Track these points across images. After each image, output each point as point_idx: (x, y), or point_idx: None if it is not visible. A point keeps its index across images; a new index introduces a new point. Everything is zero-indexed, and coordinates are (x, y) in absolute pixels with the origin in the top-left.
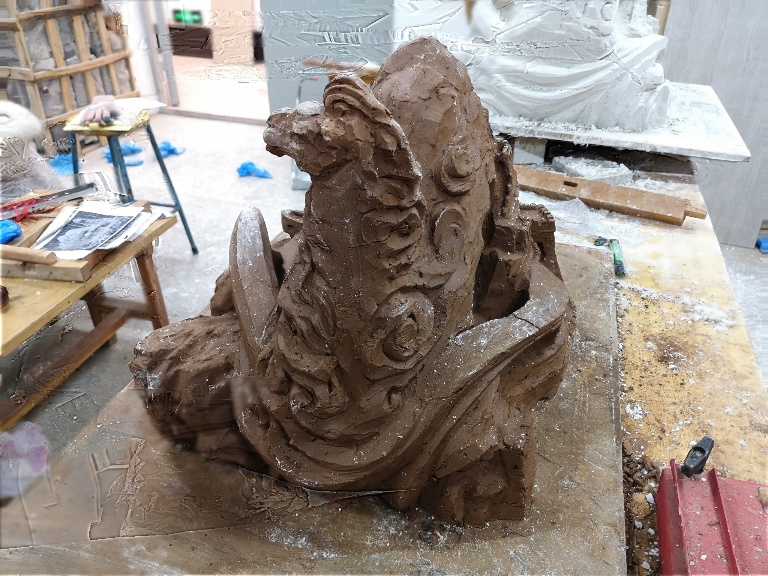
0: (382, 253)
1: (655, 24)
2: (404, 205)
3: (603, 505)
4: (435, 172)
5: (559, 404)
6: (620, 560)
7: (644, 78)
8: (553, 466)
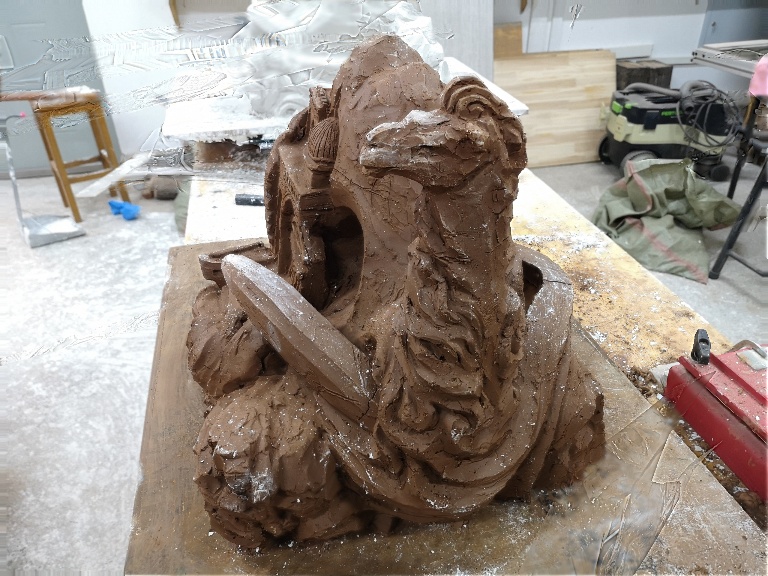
0: None
1: (411, 8)
2: (515, 197)
3: None
4: None
5: None
6: (688, 452)
7: (430, 56)
8: None
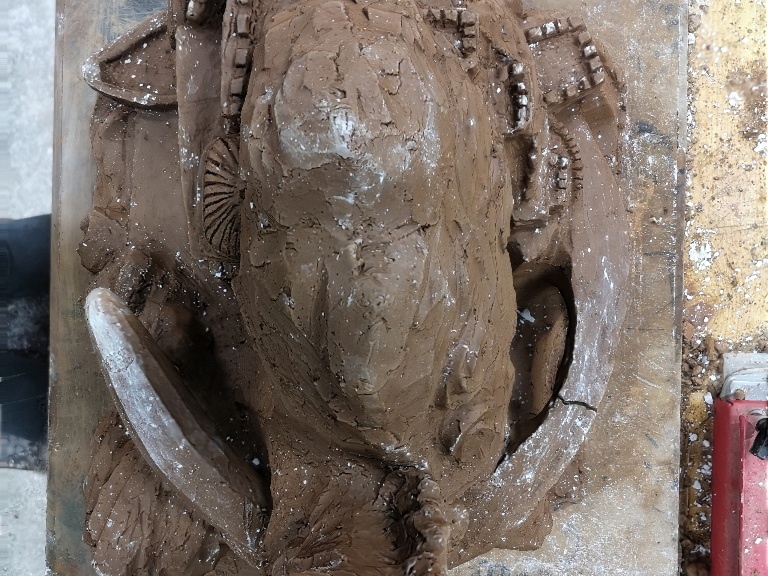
0: None
1: None
2: None
3: (657, 440)
4: (436, 402)
5: None
6: (673, 504)
7: None
8: None
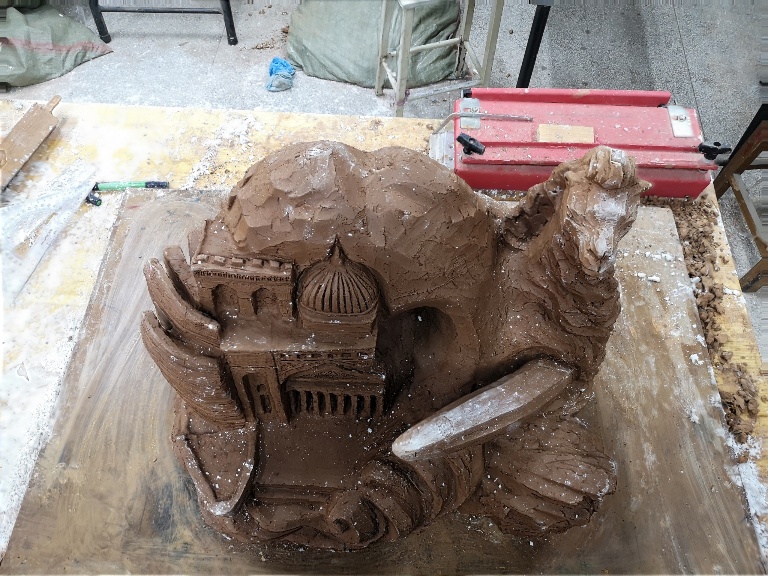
0: None
1: None
2: None
3: None
4: None
5: None
6: (516, 204)
7: None
8: None
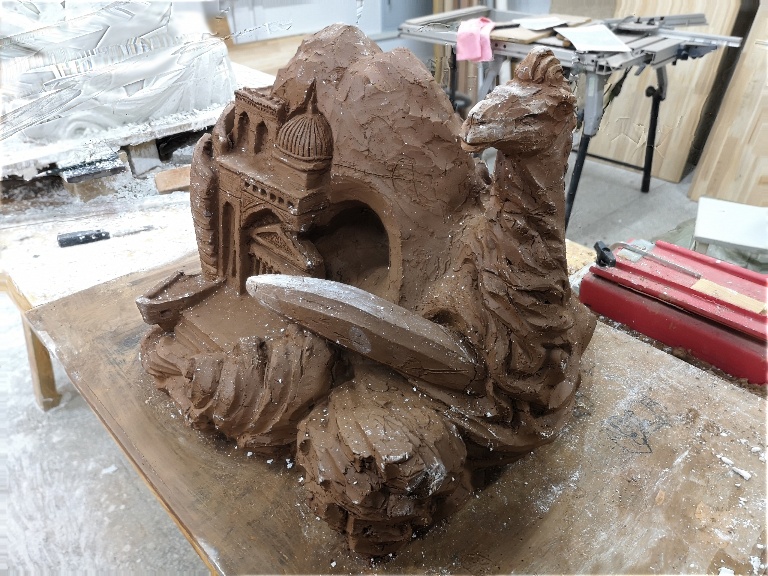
0: None
1: None
2: None
3: None
4: None
5: None
6: (626, 336)
7: (214, 53)
8: None
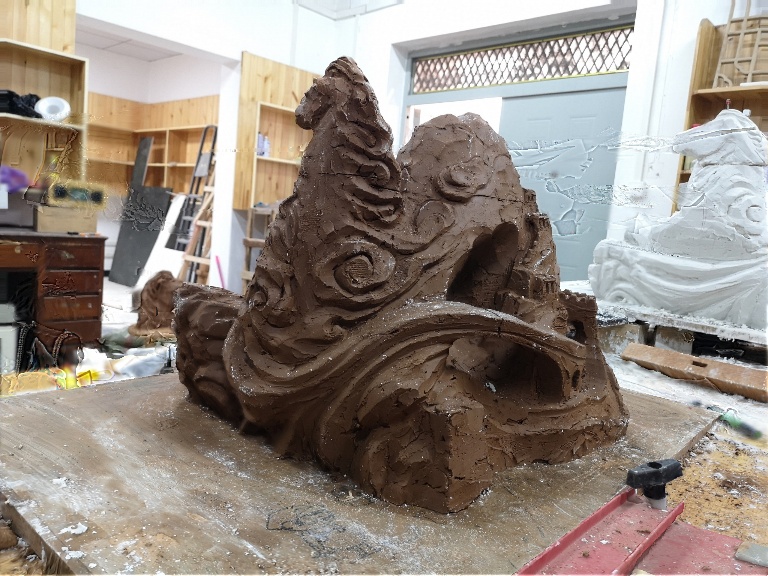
0: (346, 185)
1: None
2: (370, 152)
3: (547, 534)
4: (435, 177)
5: (559, 470)
6: None
7: None
8: (513, 498)
